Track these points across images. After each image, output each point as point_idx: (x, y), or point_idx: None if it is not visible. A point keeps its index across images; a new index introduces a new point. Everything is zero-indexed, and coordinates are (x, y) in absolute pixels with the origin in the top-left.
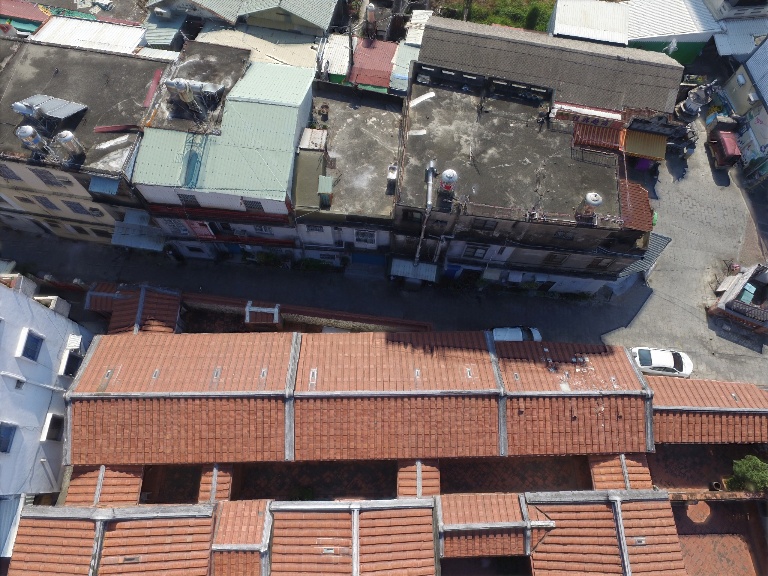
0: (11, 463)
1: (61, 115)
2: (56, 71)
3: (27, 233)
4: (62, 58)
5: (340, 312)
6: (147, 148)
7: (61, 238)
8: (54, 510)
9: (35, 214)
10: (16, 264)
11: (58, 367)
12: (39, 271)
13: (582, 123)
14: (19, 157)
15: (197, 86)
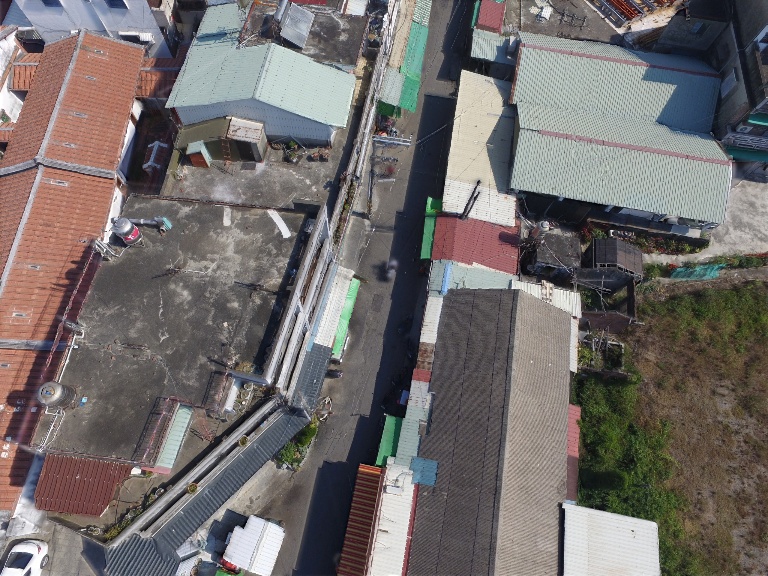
0: (42, 10)
1: None
2: None
3: None
4: None
5: None
6: (235, 7)
7: None
8: (1, 35)
9: None
10: None
11: (124, 30)
12: None
13: None
14: None
15: (277, 17)
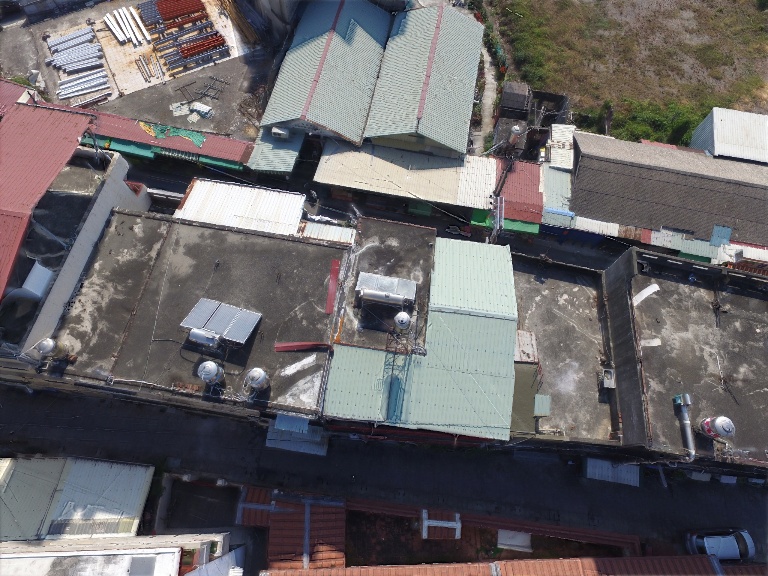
0: None
1: (241, 337)
2: (217, 263)
3: (149, 407)
4: (220, 244)
5: (530, 523)
6: (339, 371)
7: (188, 413)
8: None
9: (173, 405)
10: (154, 468)
11: None
12: (167, 457)
13: (767, 270)
14: (194, 392)
15: (399, 298)
